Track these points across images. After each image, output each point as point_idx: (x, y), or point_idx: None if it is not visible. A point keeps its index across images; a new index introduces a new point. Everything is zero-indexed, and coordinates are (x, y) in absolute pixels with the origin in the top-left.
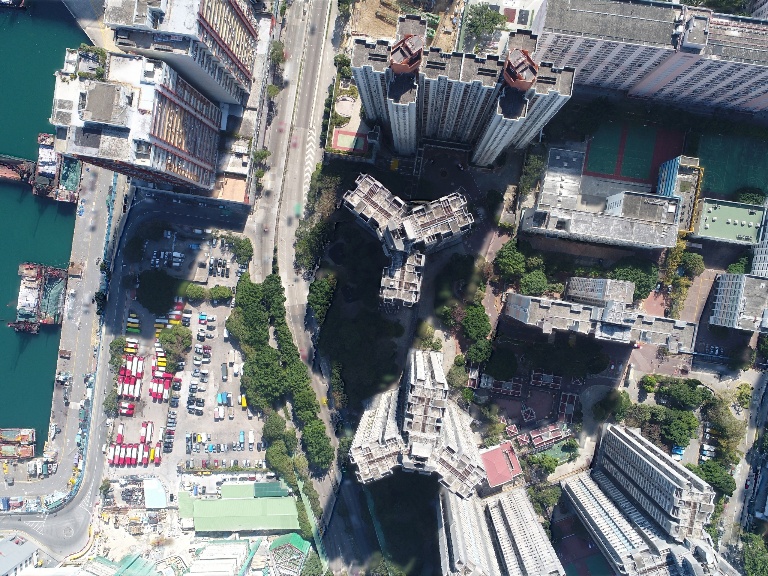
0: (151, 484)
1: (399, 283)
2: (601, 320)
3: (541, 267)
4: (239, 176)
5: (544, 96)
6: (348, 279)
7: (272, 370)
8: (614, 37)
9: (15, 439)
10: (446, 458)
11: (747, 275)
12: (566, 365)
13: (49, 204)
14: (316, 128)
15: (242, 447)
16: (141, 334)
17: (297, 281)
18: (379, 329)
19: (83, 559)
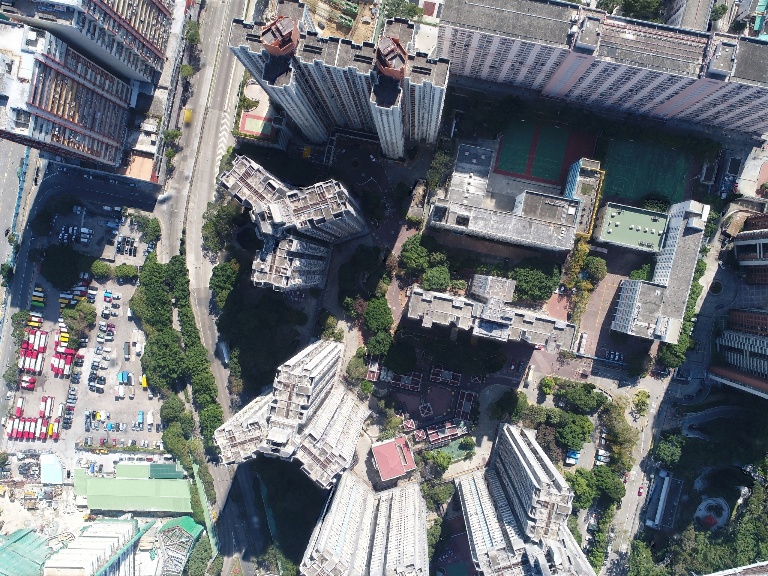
0: (48, 459)
1: (270, 267)
2: (480, 317)
3: (445, 263)
4: (147, 154)
5: (419, 86)
6: None
7: (170, 351)
8: (510, 33)
9: None
10: (308, 445)
11: (643, 281)
12: (464, 362)
13: None
14: (231, 111)
15: (141, 427)
16: (46, 308)
17: (204, 264)
18: (280, 316)
19: None
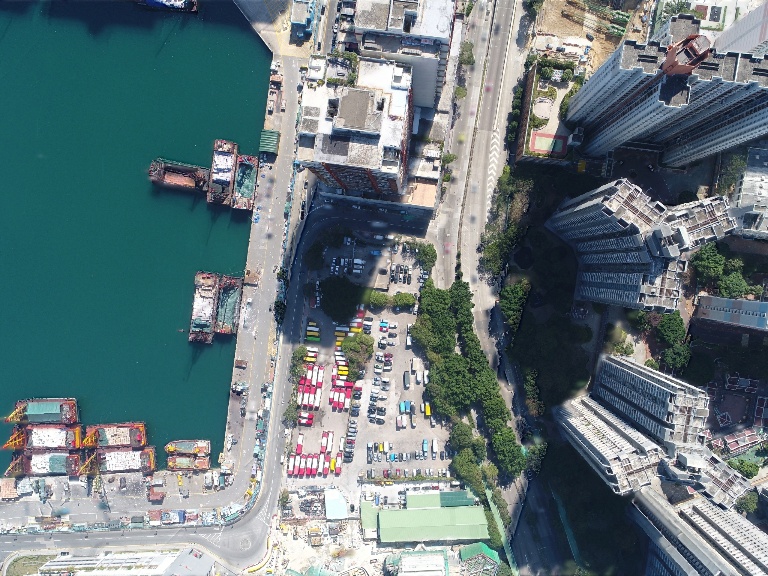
0: (332, 495)
1: (660, 290)
2: None
3: (739, 269)
4: (430, 181)
5: None
6: (539, 284)
7: (464, 378)
8: None
9: (193, 451)
10: (708, 468)
11: None
12: (767, 369)
13: (222, 212)
14: (500, 130)
15: (425, 456)
16: (320, 343)
17: (481, 286)
18: (571, 334)
19: (261, 571)
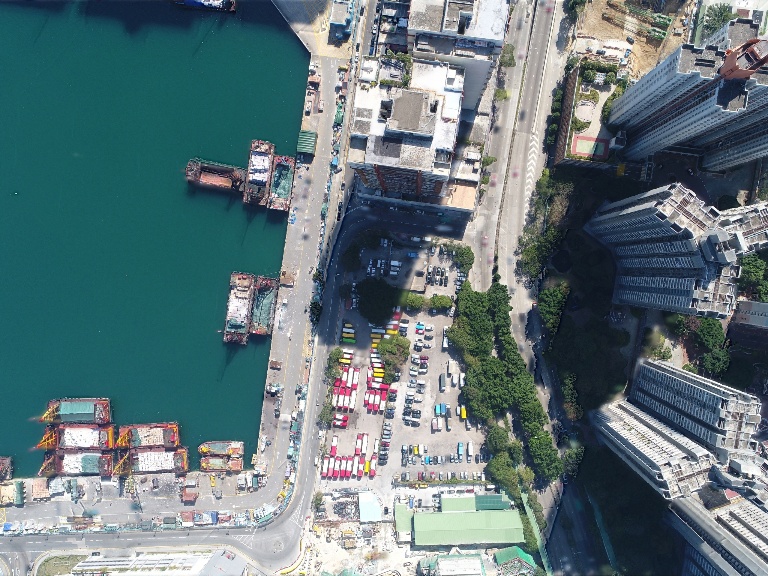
0: (366, 497)
1: (713, 295)
2: None
3: None
4: (470, 183)
5: None
6: (577, 287)
7: (501, 381)
8: None
9: (227, 452)
10: (759, 475)
11: None
12: None
13: (258, 212)
14: (539, 133)
15: (460, 459)
16: (355, 344)
17: (518, 289)
18: (610, 338)
19: (294, 573)
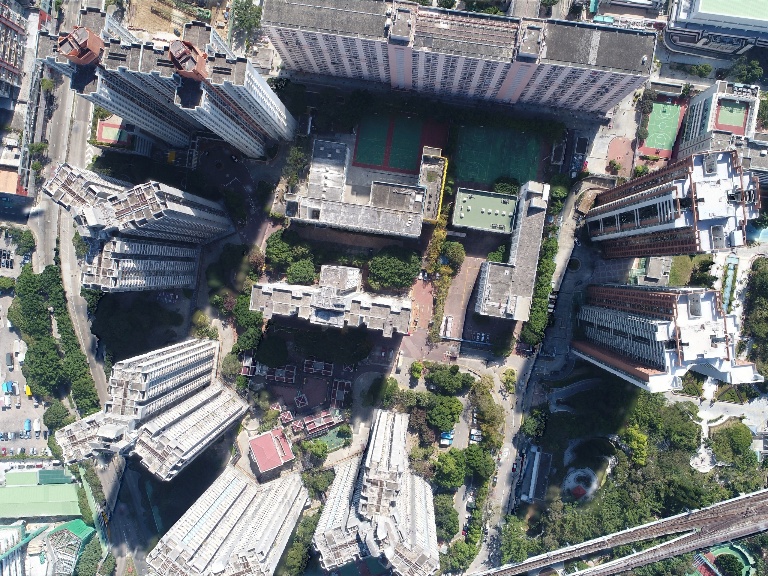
0: None
1: (97, 269)
2: None
3: (309, 256)
4: (11, 168)
5: (222, 86)
6: None
7: (47, 359)
8: (330, 30)
9: None
10: (146, 440)
11: (491, 262)
12: (332, 352)
13: None
14: None
15: (28, 435)
16: None
17: (80, 272)
18: (153, 318)
19: None
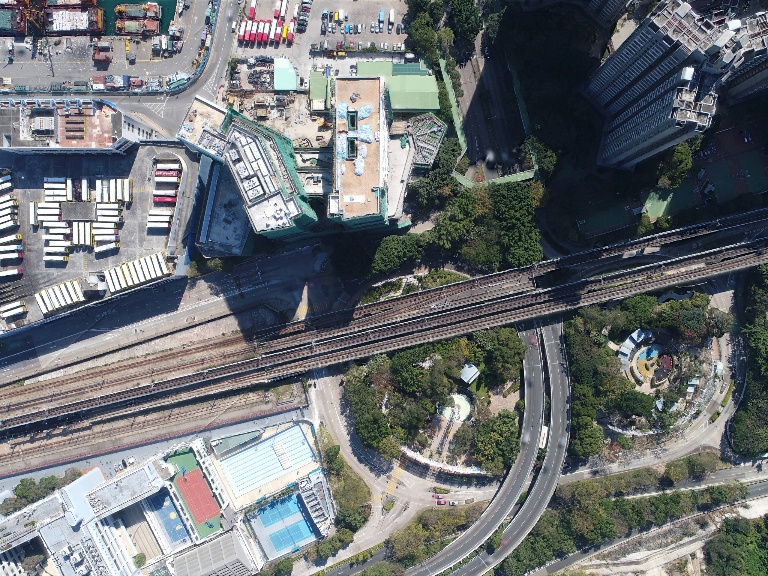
0: (282, 63)
1: None
2: None
3: None
4: None
5: None
6: None
7: None
8: None
9: (143, 6)
10: None
11: None
12: None
13: None
14: None
15: (381, 27)
16: None
17: None
18: None
19: None
